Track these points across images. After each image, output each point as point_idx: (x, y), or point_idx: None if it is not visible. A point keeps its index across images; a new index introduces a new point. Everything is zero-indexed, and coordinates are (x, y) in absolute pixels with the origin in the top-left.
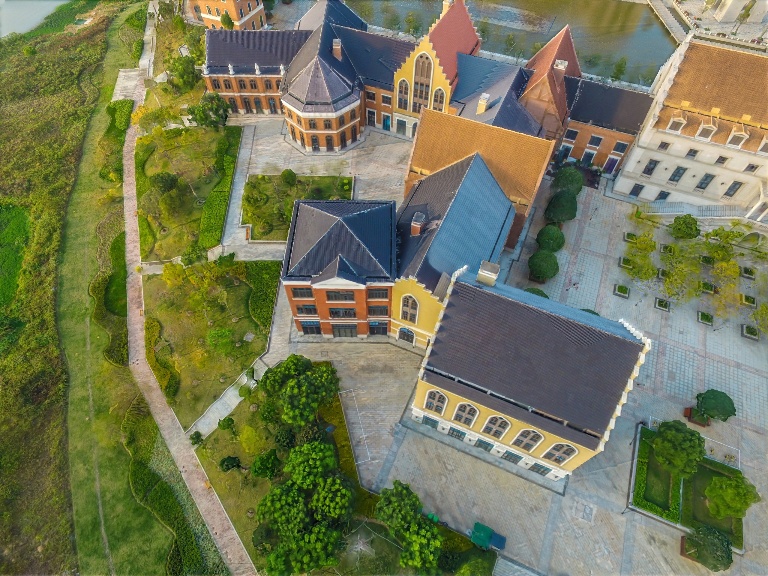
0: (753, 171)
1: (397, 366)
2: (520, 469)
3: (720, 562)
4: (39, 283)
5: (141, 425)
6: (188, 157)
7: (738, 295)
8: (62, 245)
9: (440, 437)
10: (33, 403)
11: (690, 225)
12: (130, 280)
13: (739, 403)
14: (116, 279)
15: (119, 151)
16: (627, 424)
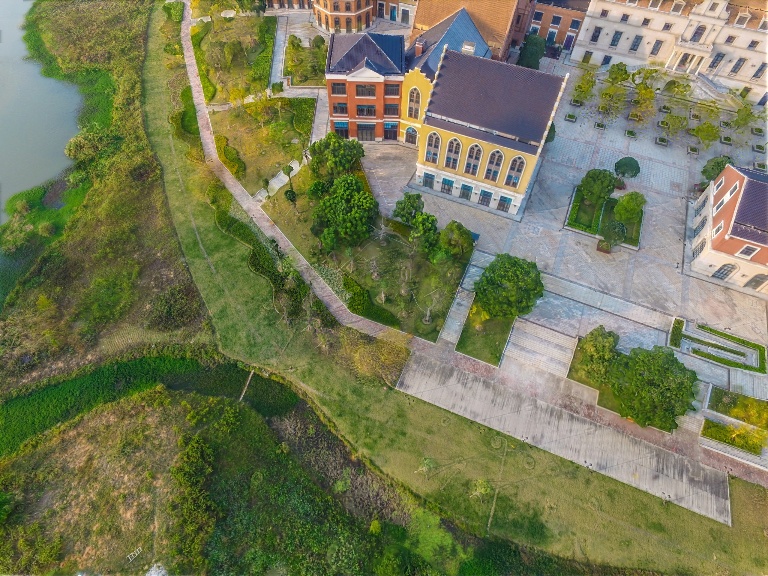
0: (669, 30)
1: (404, 157)
2: (491, 209)
3: (617, 234)
4: (130, 115)
5: (220, 193)
6: (238, 31)
7: (656, 122)
8: (143, 93)
9: (435, 193)
10: (139, 181)
11: (621, 67)
12: (199, 114)
13: (648, 178)
14: (188, 113)
15: (178, 35)
16: (567, 188)
